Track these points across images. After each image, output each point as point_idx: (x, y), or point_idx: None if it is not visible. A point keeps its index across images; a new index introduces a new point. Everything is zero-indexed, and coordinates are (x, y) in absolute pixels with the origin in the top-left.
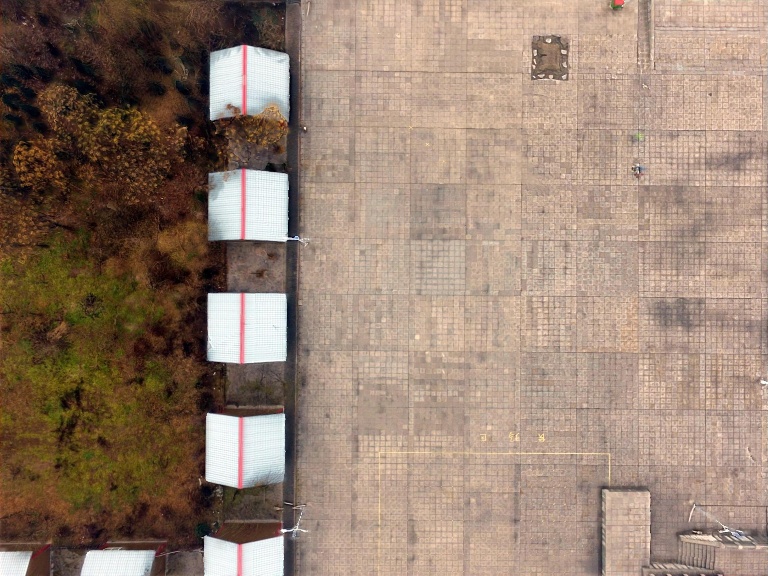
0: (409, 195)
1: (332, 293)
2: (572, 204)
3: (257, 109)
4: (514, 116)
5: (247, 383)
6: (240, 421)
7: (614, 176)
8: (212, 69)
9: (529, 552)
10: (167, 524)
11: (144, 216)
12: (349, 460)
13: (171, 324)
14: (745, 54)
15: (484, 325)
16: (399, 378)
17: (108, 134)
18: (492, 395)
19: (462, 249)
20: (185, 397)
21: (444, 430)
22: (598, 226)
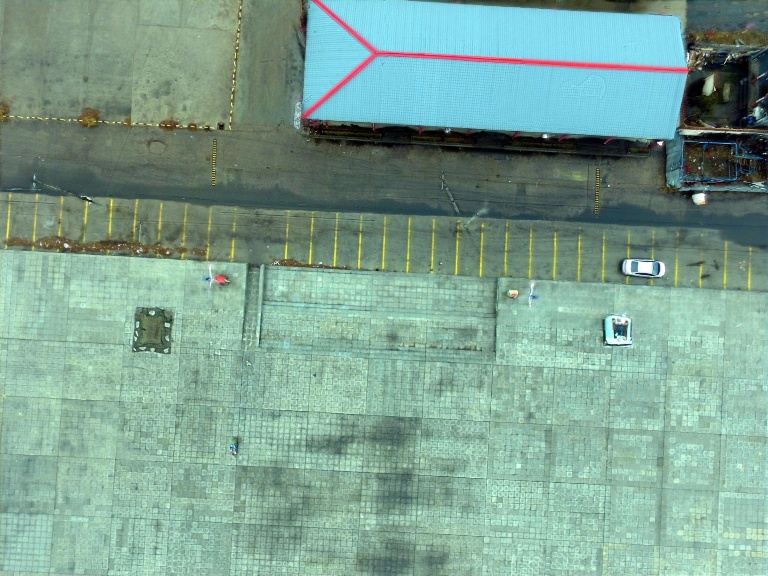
0: None
1: None
2: (167, 482)
3: None
4: (112, 388)
5: None
6: None
7: (212, 454)
8: None
9: None
10: None
11: None
12: None
13: None
14: (355, 334)
15: None
16: None
17: None
18: None
19: (49, 524)
20: None
21: None
22: (192, 506)
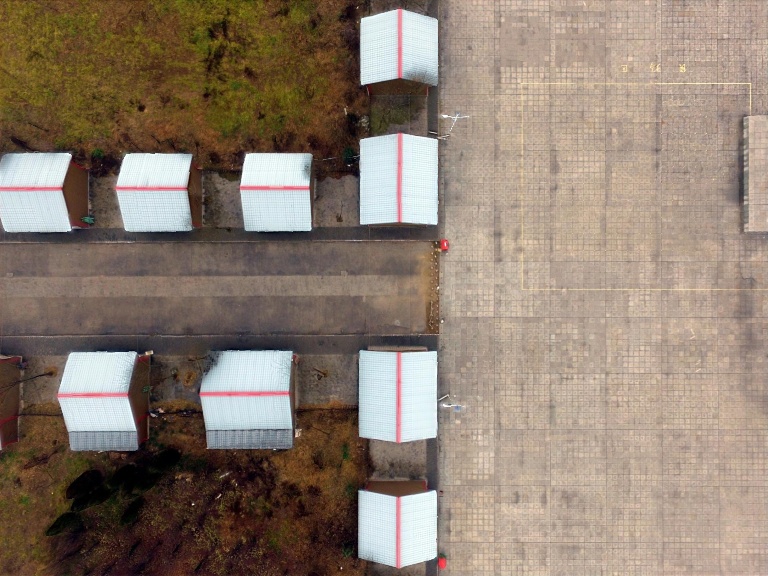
0: None
1: None
2: None
3: None
4: None
5: None
6: (400, 12)
7: None
8: None
9: (671, 181)
10: (314, 153)
11: None
12: (492, 91)
13: None
14: None
15: None
16: (540, 10)
17: None
18: (633, 26)
19: None
20: (329, 30)
21: (586, 61)
22: None
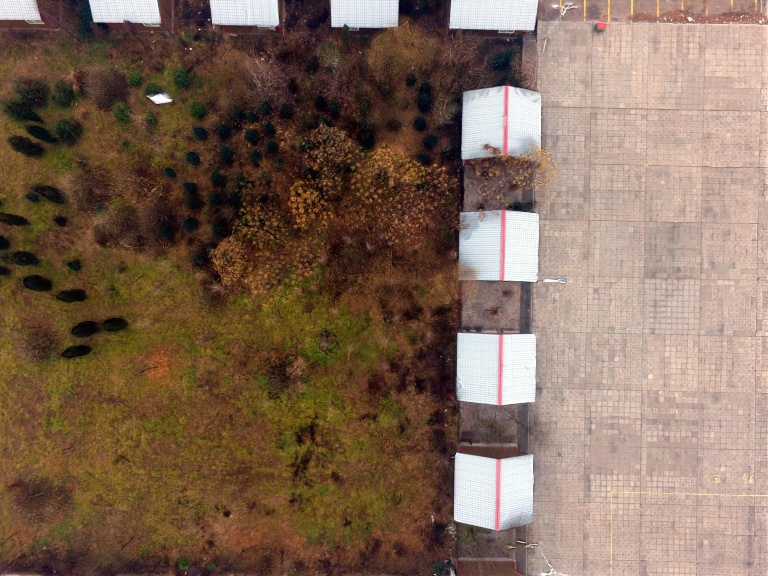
0: (644, 233)
1: (565, 331)
2: None
3: (516, 150)
4: (751, 154)
5: (481, 420)
6: (498, 463)
7: None
8: (466, 108)
9: None
10: (400, 560)
11: (378, 252)
12: (581, 499)
13: (403, 360)
14: None
15: (718, 365)
16: (632, 417)
17: (383, 176)
18: (726, 436)
19: (697, 288)
20: (417, 433)
21: (677, 471)
22: None
